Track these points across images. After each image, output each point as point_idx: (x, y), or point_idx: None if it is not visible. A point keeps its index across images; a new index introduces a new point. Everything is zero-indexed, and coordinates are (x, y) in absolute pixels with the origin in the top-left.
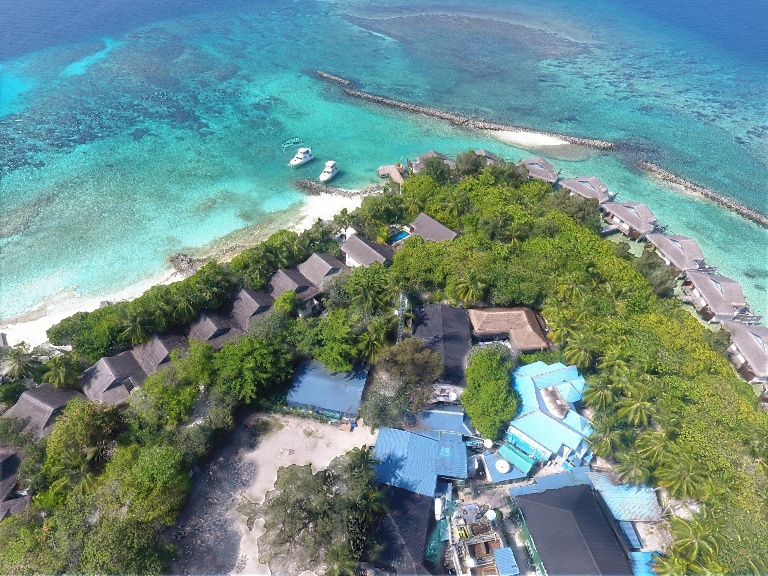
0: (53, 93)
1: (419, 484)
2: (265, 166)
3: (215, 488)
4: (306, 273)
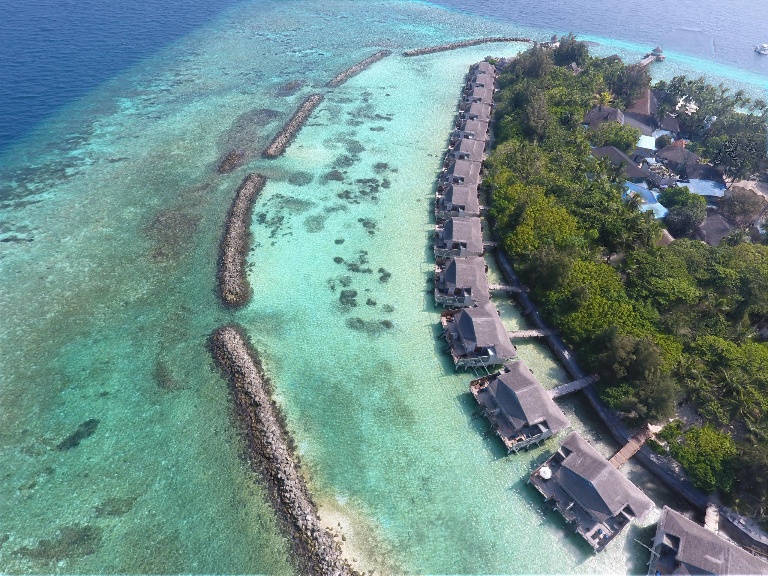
0: None
1: None
2: None
3: None
4: None
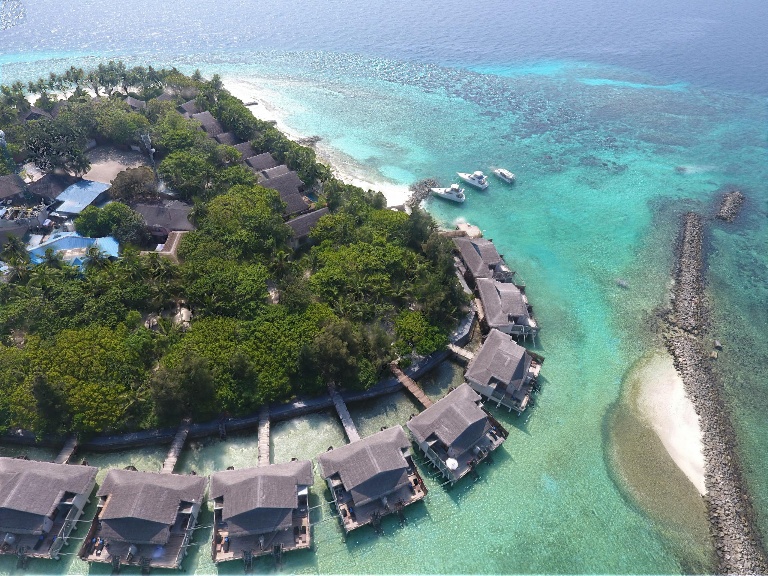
0: (541, 81)
1: (66, 194)
2: (459, 166)
3: (128, 157)
4: None
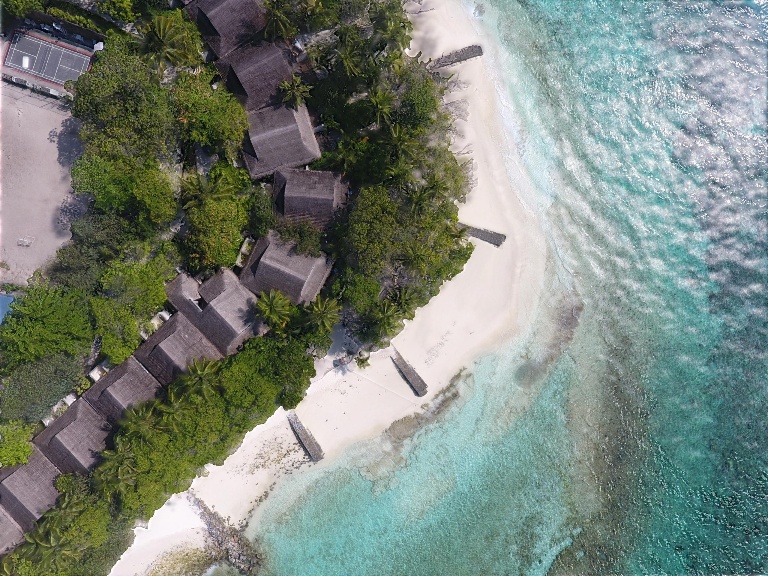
0: None
1: None
2: None
3: None
4: (8, 523)
